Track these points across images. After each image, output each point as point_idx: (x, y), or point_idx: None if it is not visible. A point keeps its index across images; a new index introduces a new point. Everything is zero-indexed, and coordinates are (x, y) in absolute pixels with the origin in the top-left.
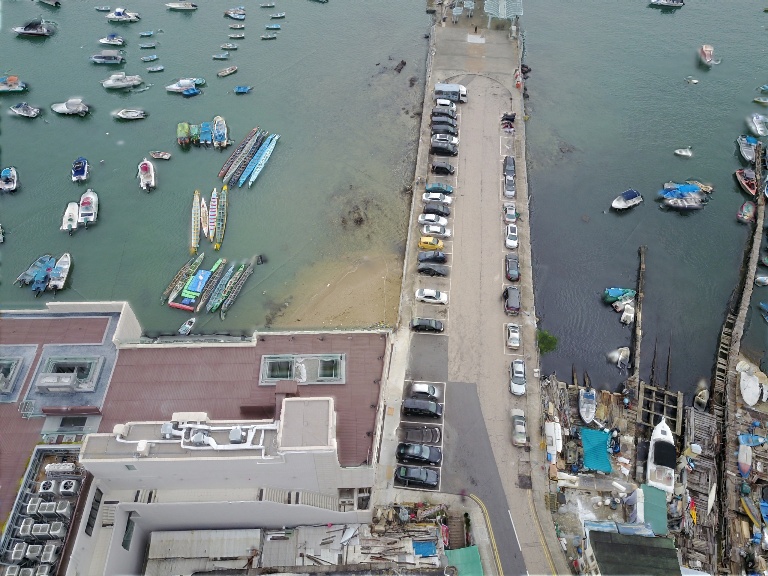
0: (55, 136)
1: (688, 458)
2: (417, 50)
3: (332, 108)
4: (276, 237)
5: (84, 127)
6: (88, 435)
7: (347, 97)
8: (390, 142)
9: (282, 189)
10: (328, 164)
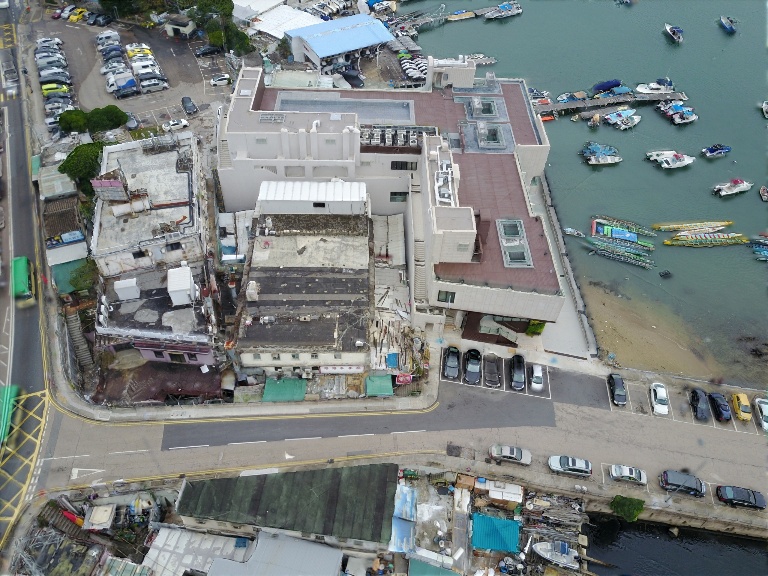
0: (755, 137)
1: None
2: None
3: None
4: (701, 286)
5: None
6: (441, 137)
7: None
8: None
9: None
10: None
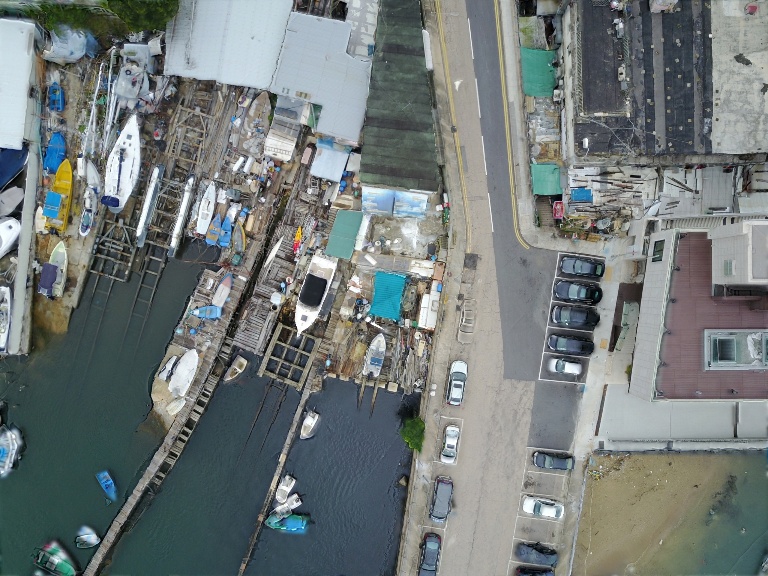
0: None
1: (284, 293)
2: None
3: None
4: None
5: None
6: None
7: None
8: None
9: None
10: None
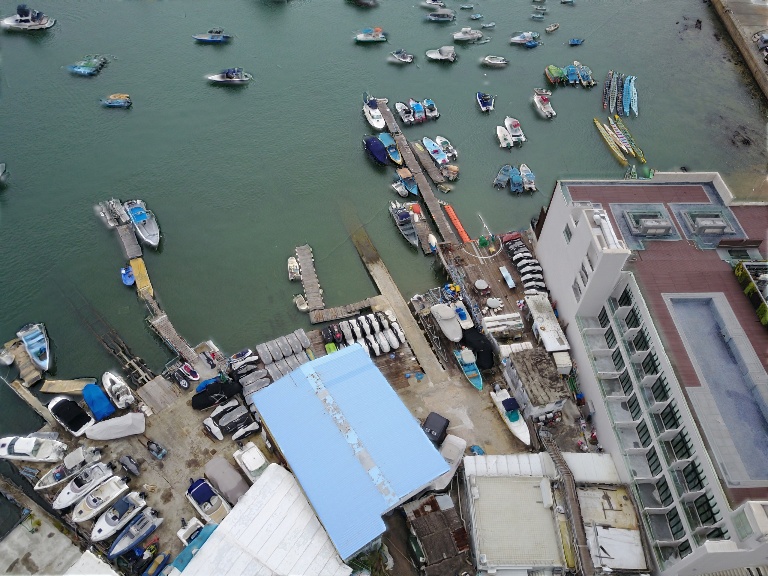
0: None
1: None
2: (704, 12)
3: (661, 57)
4: (683, 154)
5: (453, 71)
6: None
7: (669, 48)
8: (730, 83)
9: (661, 119)
10: (688, 100)
